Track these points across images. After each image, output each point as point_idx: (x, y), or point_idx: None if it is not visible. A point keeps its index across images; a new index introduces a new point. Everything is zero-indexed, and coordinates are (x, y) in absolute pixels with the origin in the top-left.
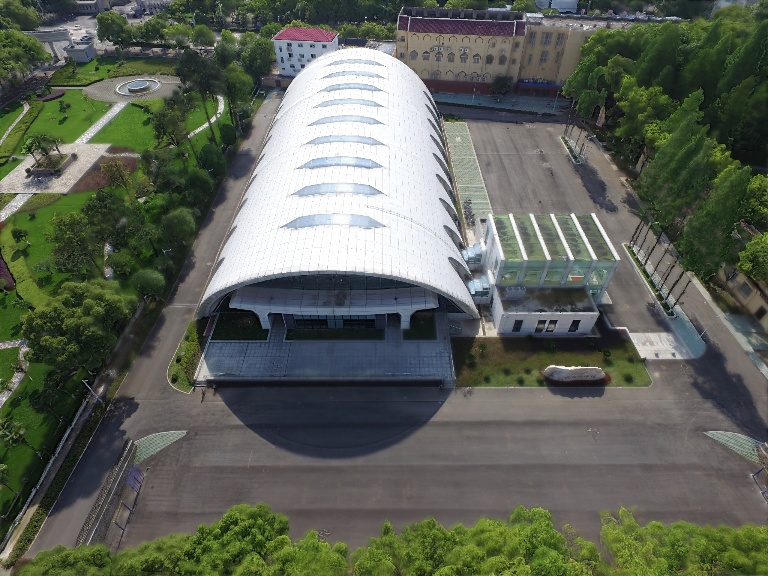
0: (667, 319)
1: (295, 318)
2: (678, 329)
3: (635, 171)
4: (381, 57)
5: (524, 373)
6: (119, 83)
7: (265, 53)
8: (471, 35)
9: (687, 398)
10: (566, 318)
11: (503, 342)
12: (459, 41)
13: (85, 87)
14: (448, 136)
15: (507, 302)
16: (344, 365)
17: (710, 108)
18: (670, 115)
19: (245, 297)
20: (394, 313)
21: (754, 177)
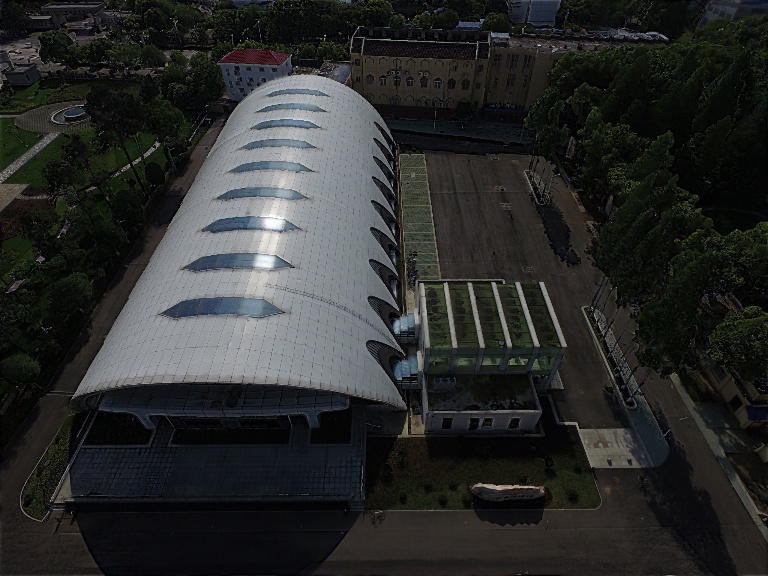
0: (626, 410)
1: (182, 418)
2: (638, 425)
3: (604, 213)
4: (327, 85)
5: (449, 489)
6: (55, 110)
7: (210, 77)
8: (430, 58)
9: (642, 525)
10: (503, 416)
11: (428, 445)
12: (417, 64)
13: (19, 115)
14: (402, 171)
15: (435, 395)
16: (234, 480)
17: (683, 149)
18: (637, 158)
19: (118, 397)
20: (297, 414)
21: (731, 233)
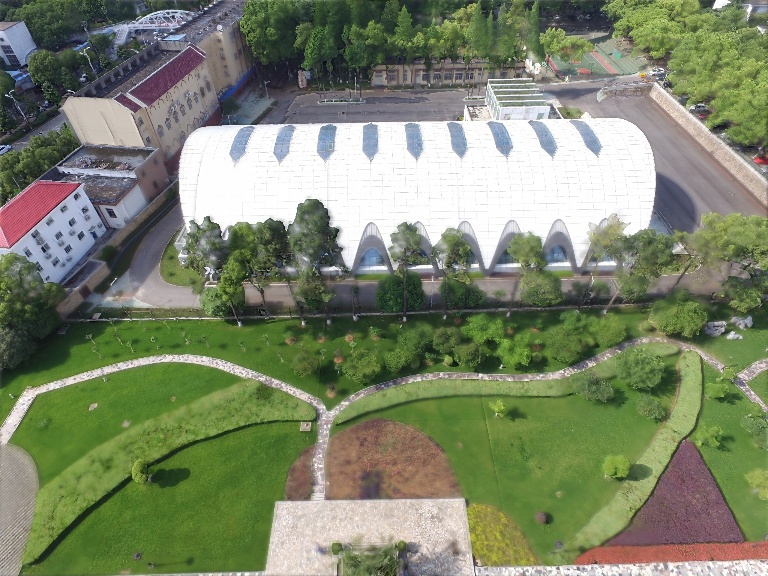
0: None
1: None
2: None
3: (376, 85)
4: (222, 127)
5: None
6: None
7: (32, 271)
8: (185, 76)
9: (582, 102)
10: None
11: None
12: (180, 89)
13: None
14: None
15: None
16: None
17: (385, 21)
18: None
19: None
20: None
21: None
